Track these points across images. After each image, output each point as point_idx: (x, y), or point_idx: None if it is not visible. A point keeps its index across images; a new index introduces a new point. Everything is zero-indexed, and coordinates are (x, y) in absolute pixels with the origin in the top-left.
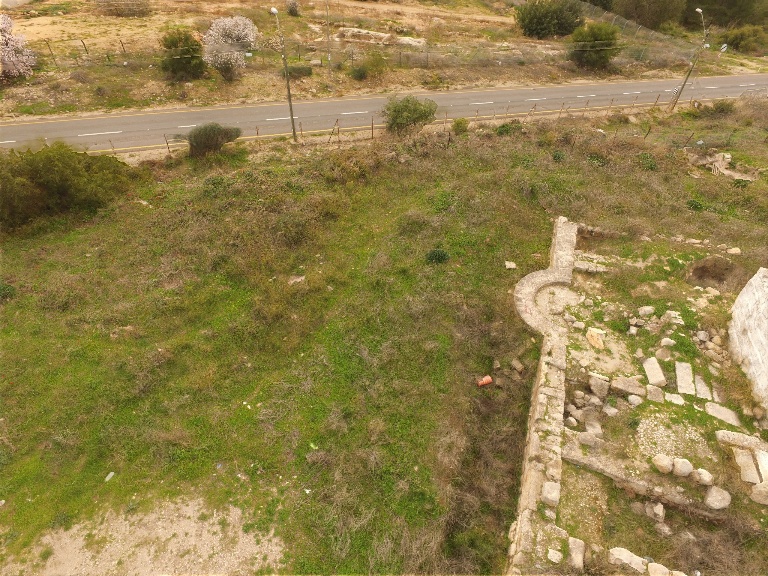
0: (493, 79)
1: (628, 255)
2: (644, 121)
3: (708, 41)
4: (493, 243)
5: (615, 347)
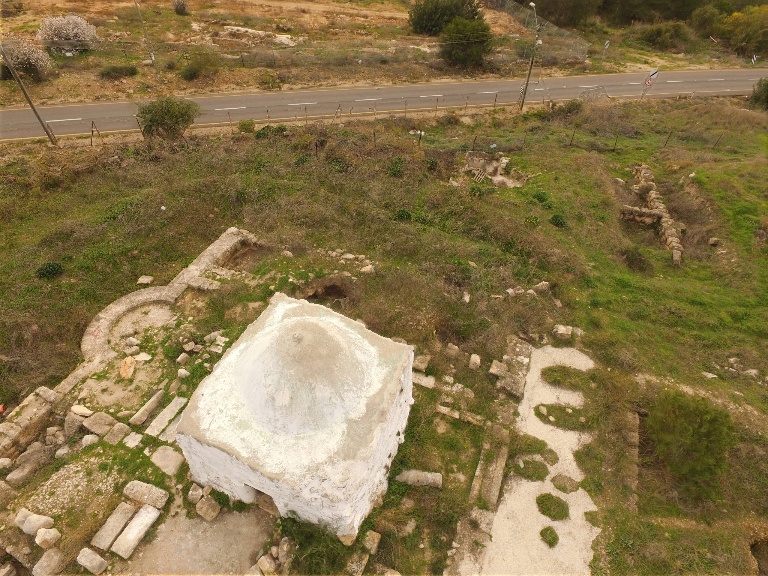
0: (344, 78)
1: (259, 271)
2: (480, 122)
3: (540, 37)
4: (140, 255)
5: (141, 376)
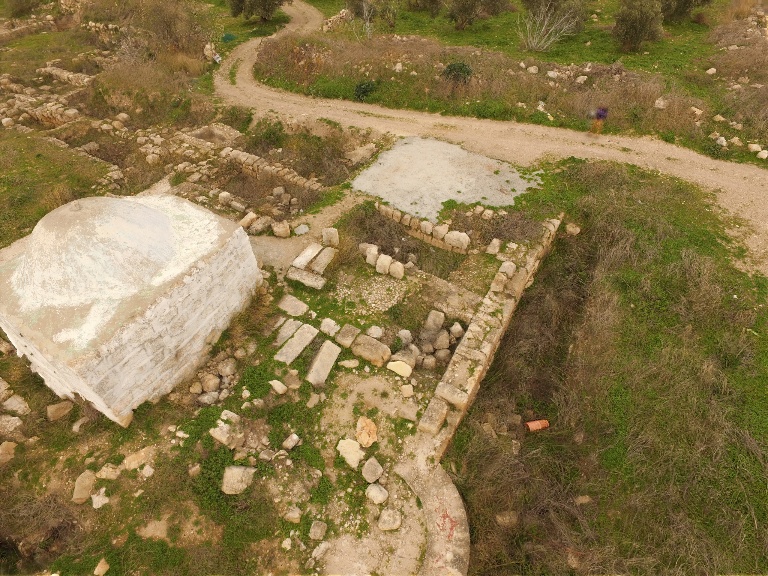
0: None
1: None
2: None
3: None
4: None
5: (344, 414)
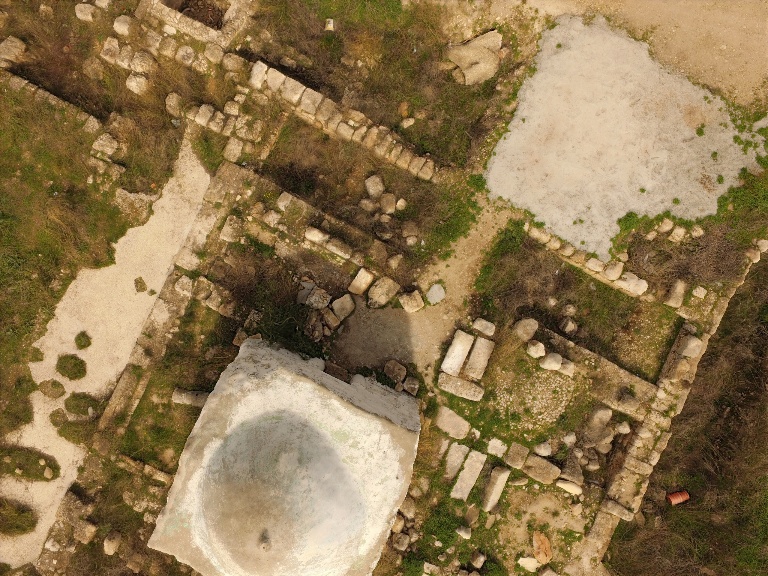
0: None
1: None
2: None
3: None
4: None
5: (520, 533)
